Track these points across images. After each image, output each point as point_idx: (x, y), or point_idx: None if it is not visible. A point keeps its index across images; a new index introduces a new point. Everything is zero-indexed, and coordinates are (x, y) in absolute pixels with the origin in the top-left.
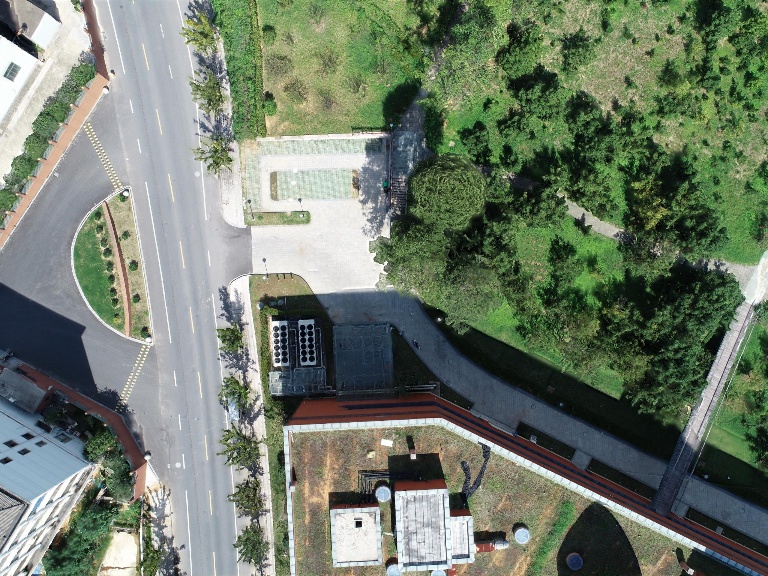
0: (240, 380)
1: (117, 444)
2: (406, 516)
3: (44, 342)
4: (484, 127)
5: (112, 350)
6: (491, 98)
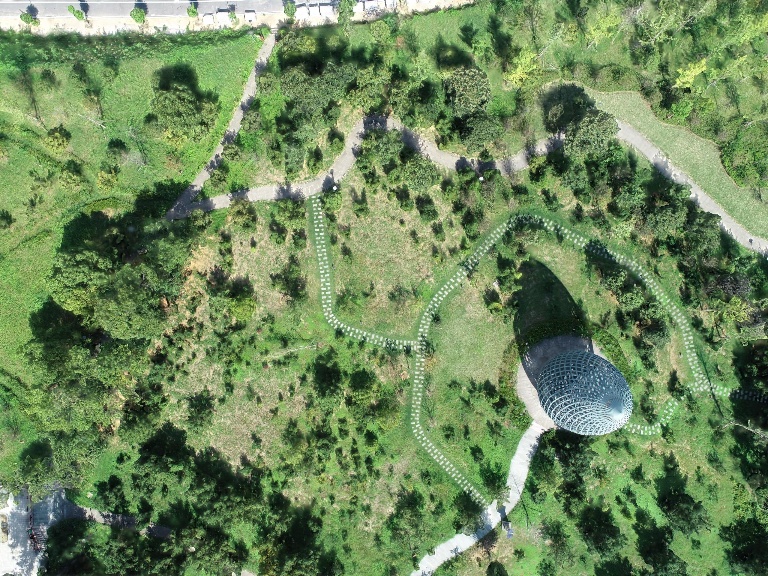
0: None
1: None
2: None
3: None
4: (119, 480)
5: None
6: (124, 453)
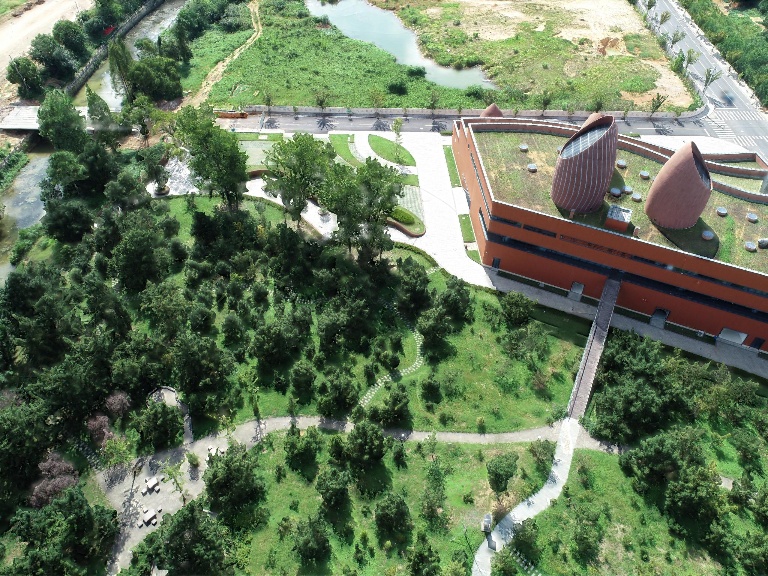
0: None
1: None
2: None
3: None
4: None
5: None
6: None
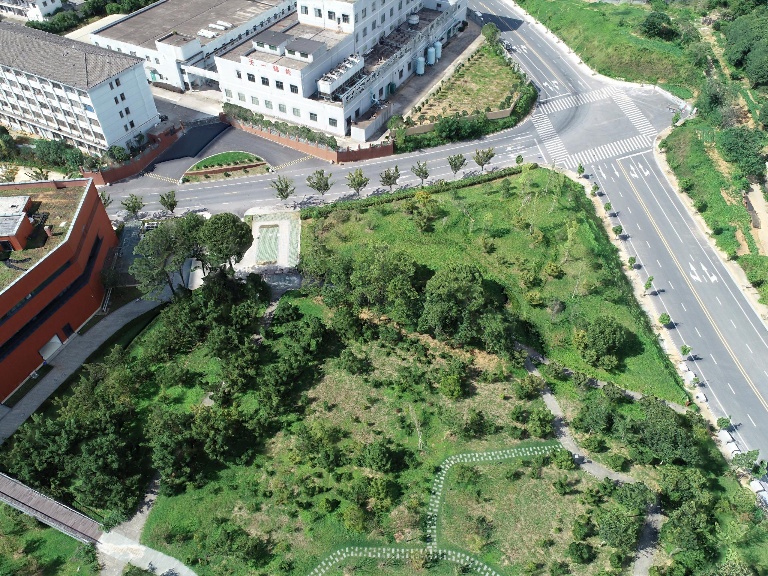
0: (144, 219)
1: (119, 163)
2: (7, 219)
3: (189, 144)
4: (299, 319)
5: (178, 168)
6: (321, 321)
